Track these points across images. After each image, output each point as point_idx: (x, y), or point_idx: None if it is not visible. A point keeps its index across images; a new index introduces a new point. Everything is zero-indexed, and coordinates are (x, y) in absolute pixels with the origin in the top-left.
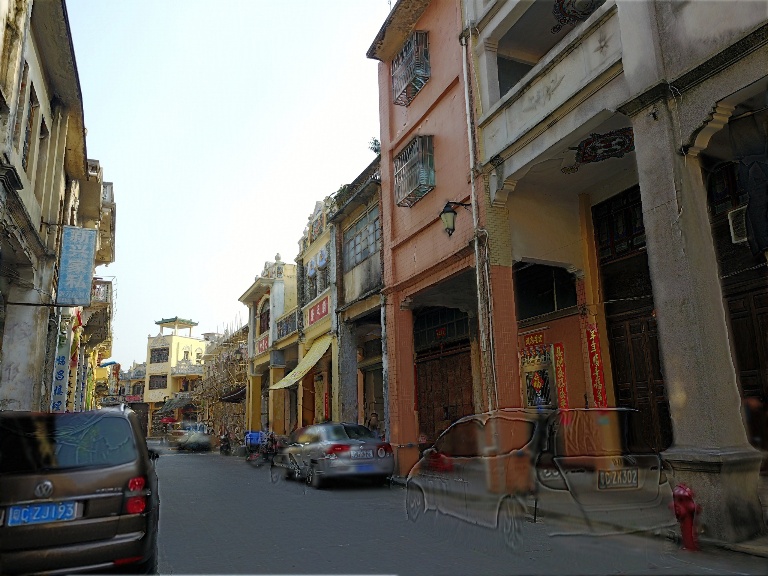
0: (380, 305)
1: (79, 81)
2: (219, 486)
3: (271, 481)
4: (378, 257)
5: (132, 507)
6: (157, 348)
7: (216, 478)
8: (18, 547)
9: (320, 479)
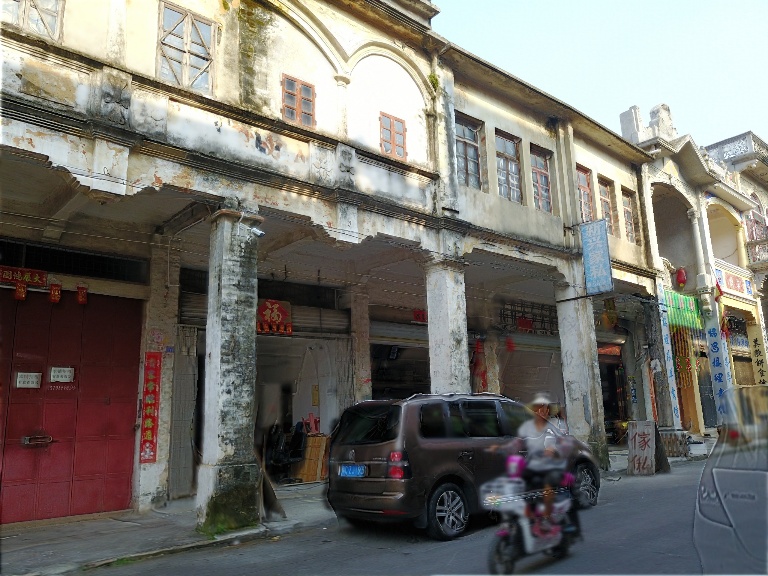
0: None
1: (552, 98)
2: None
3: None
4: None
5: (395, 473)
6: None
7: None
8: (346, 490)
9: None
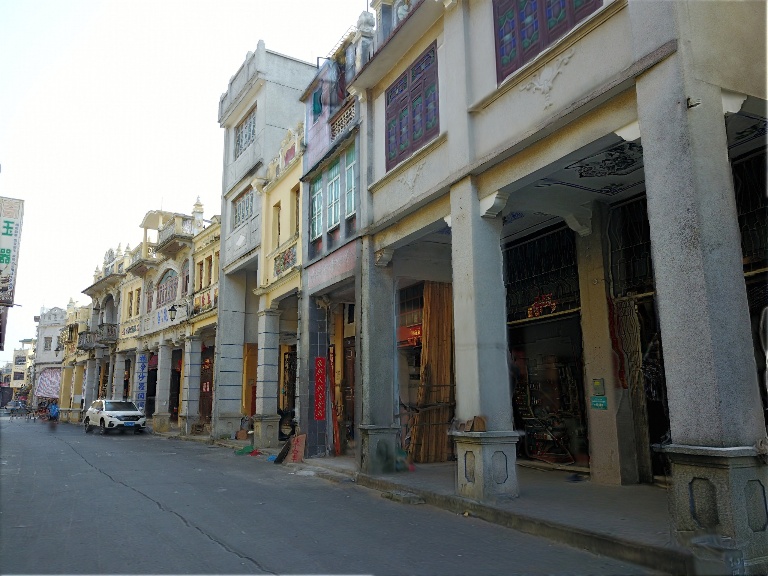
0: None
1: None
2: None
3: None
4: None
5: None
6: (19, 356)
7: None
8: None
9: None
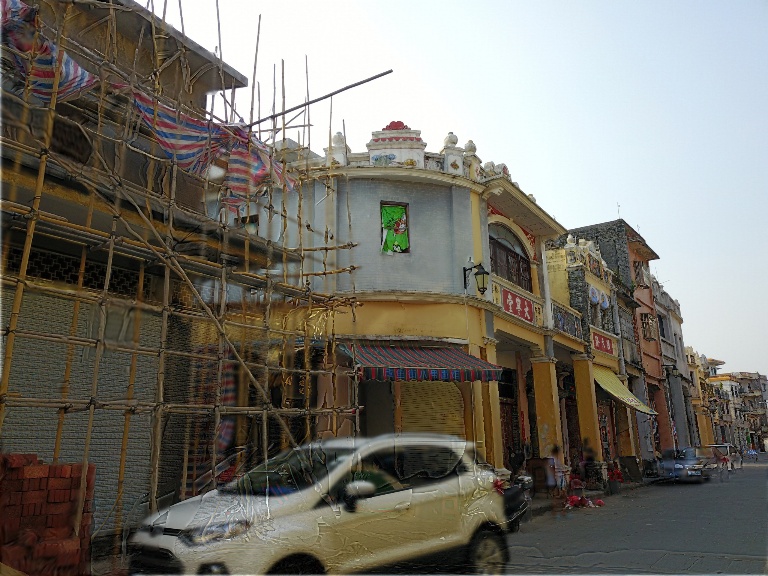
0: (637, 376)
1: None
2: None
3: (721, 482)
4: (635, 348)
5: None
6: None
7: None
8: None
9: None
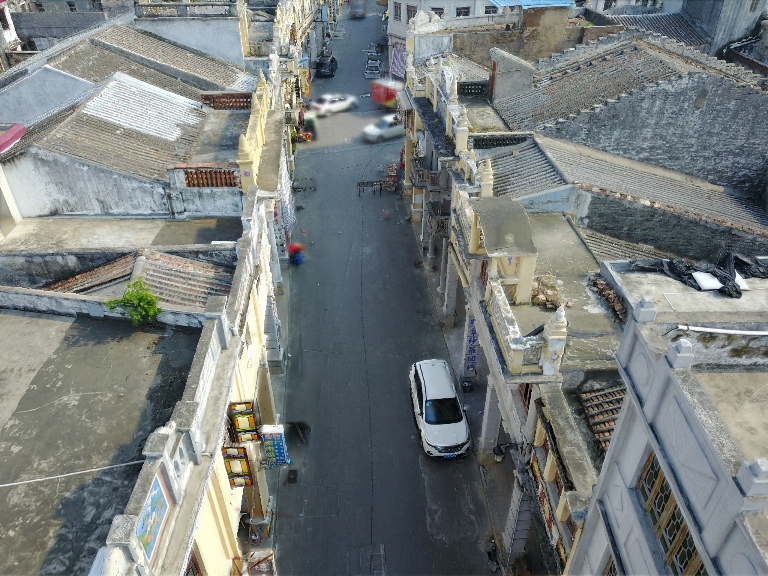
0: None
1: None
2: None
3: None
4: None
5: (330, 70)
6: None
7: (361, 47)
8: (322, 73)
9: (368, 58)
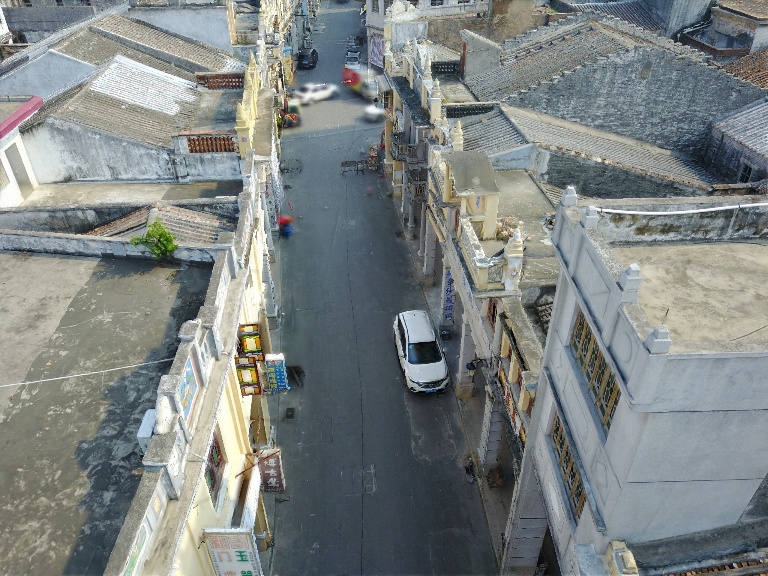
0: None
1: None
2: (337, 45)
3: None
4: None
5: (312, 62)
6: None
7: None
8: (304, 65)
9: None
